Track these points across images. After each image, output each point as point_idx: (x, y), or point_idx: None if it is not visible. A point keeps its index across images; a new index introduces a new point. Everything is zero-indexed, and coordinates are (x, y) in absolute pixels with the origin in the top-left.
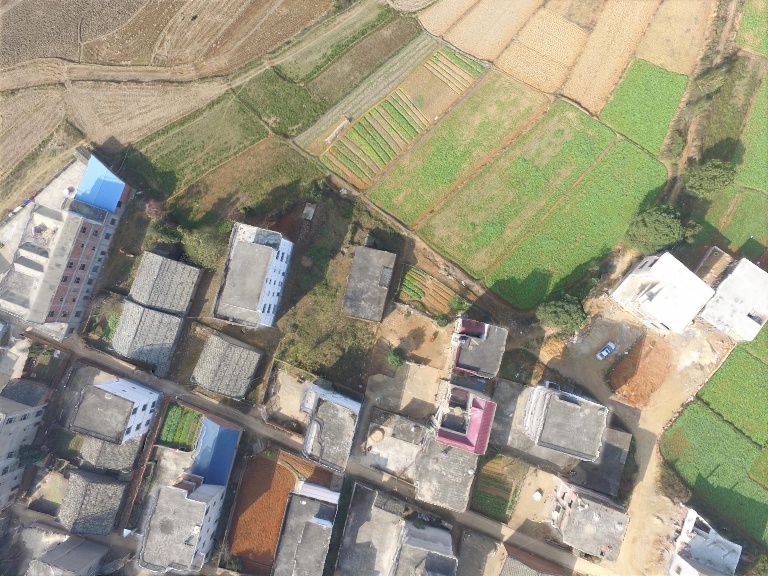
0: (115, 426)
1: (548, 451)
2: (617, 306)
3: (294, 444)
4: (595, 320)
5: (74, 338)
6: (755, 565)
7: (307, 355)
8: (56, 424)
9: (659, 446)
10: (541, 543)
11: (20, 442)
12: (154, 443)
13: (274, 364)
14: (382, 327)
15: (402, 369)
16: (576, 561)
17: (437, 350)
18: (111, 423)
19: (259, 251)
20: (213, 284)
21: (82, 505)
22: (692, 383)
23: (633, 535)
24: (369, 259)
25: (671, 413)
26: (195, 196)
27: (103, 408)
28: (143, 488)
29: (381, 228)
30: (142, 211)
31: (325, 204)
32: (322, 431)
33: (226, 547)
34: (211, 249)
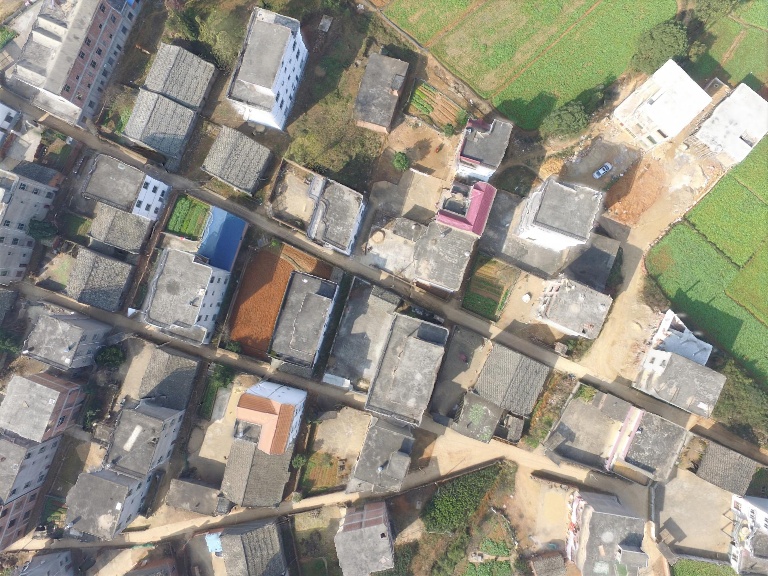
0: (126, 195)
1: (540, 260)
2: (617, 126)
3: (297, 241)
4: (595, 141)
5: (87, 124)
6: (723, 368)
7: (315, 159)
8: (66, 208)
9: (644, 261)
10: (526, 342)
11: (30, 217)
12: (161, 230)
13: (283, 163)
14: (390, 138)
15: (406, 177)
16: (557, 359)
17: (441, 161)
18: (123, 192)
19: (277, 31)
20: (227, 87)
21: (90, 276)
22: (681, 204)
23: (612, 338)
24: (382, 66)
25: (659, 232)
26: (213, 2)
27: (115, 177)
28: (149, 272)
29: (395, 45)
30: (160, 11)
31: (342, 18)
32: (327, 212)
33: (227, 329)
34: (227, 48)
